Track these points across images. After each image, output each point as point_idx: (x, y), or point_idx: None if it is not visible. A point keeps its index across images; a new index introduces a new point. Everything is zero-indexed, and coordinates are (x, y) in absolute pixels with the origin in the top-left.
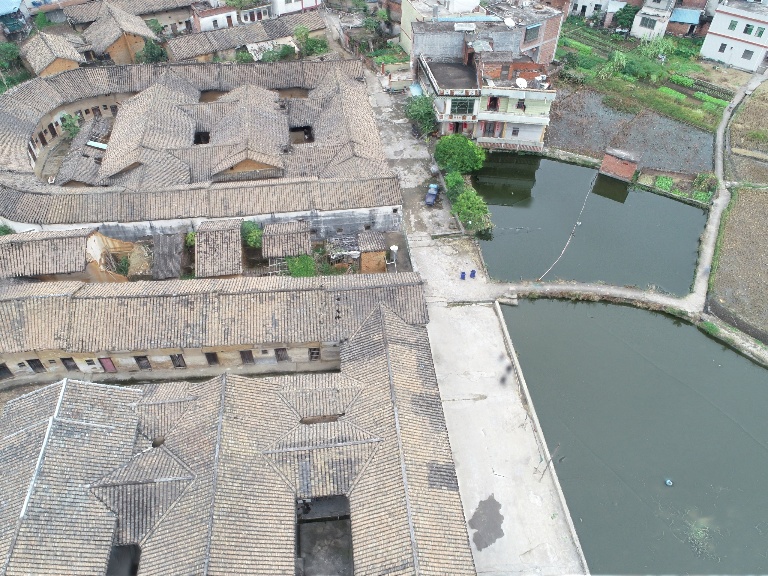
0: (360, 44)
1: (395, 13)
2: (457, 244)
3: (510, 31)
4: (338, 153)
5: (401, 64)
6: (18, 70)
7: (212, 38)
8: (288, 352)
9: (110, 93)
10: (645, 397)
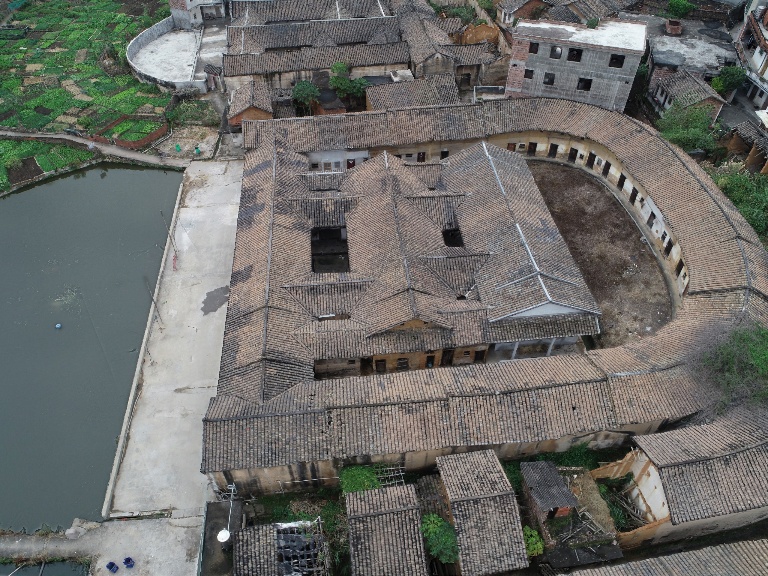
0: None
1: None
2: None
3: None
4: None
5: None
6: None
7: None
8: None
9: None
10: (14, 398)
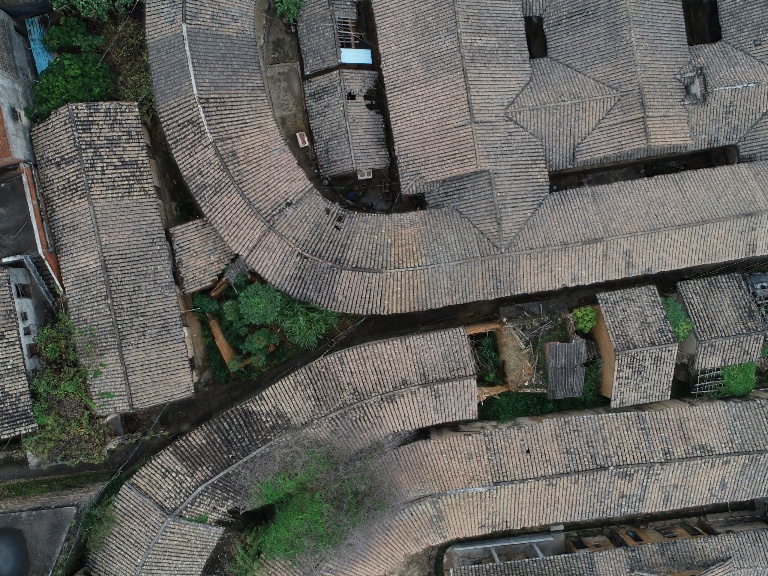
0: None
1: None
2: None
3: None
4: None
5: None
6: None
7: None
8: None
9: None
10: None
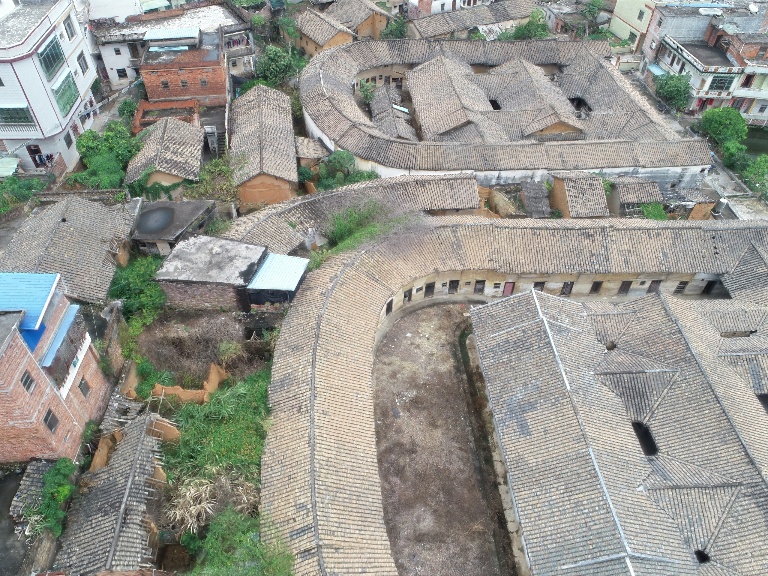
0: (578, 29)
1: (603, 1)
2: (749, 204)
3: (753, 16)
4: (630, 120)
5: (621, 48)
6: (277, 44)
7: (449, 19)
8: (661, 284)
9: (392, 64)
10: None
